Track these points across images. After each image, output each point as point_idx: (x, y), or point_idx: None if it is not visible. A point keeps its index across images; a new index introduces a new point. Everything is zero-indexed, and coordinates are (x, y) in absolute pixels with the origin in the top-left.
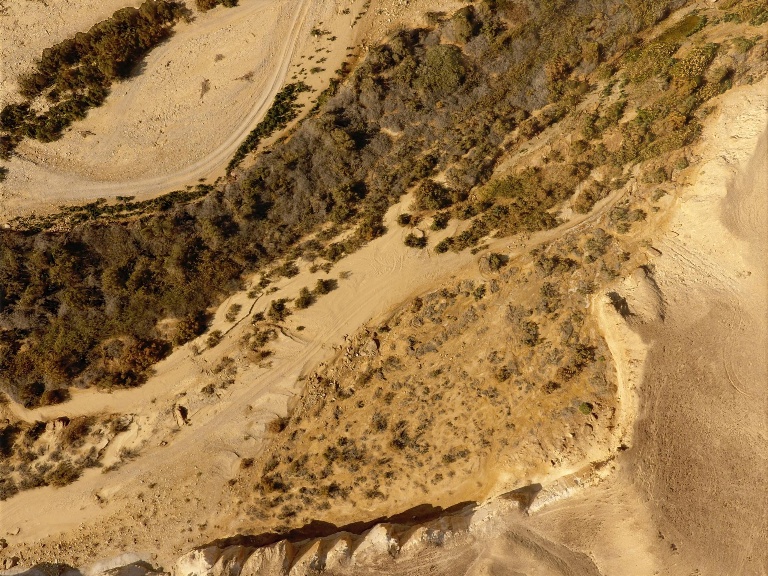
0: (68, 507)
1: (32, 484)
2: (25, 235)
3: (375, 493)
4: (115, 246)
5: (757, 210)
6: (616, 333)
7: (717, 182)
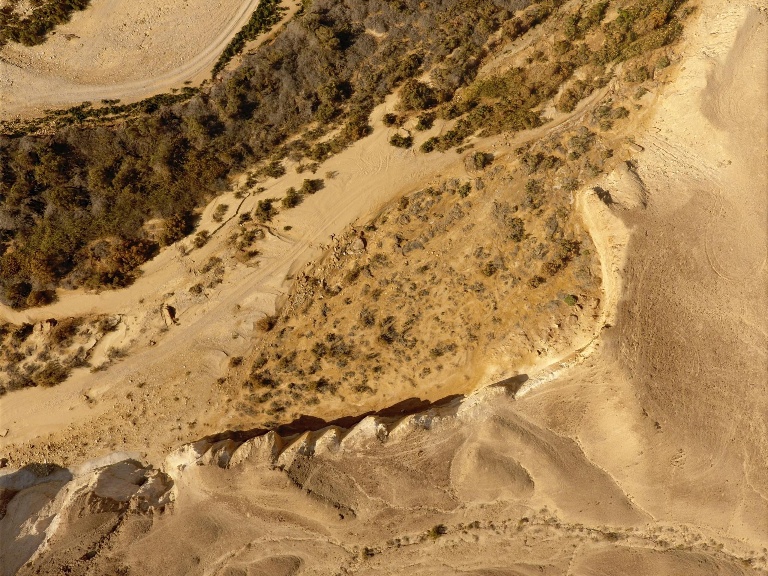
0: (57, 408)
1: (20, 384)
2: (10, 137)
3: (363, 387)
4: (101, 147)
5: (737, 101)
6: (599, 221)
7: (697, 75)
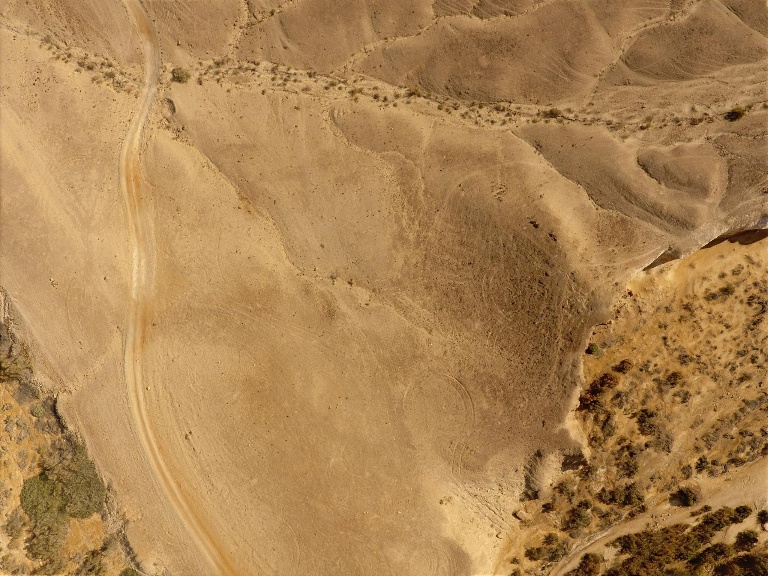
0: None
1: None
2: None
3: None
4: None
5: (430, 572)
6: None
7: None
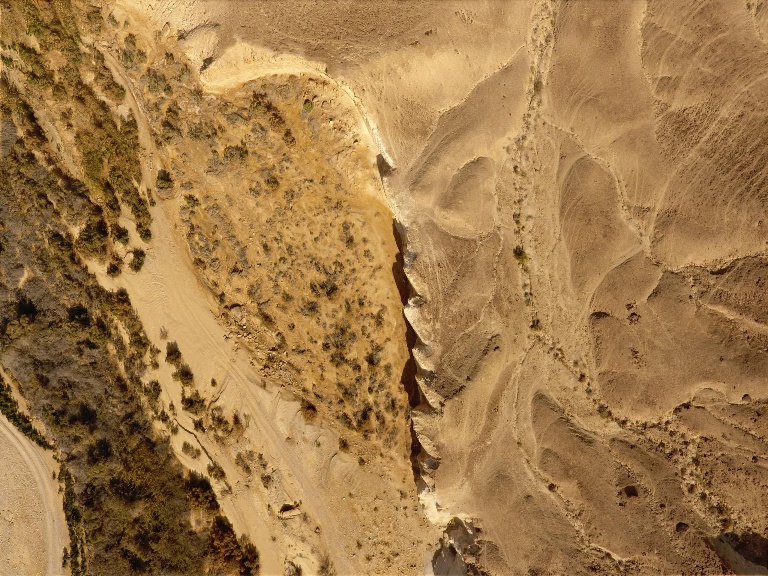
0: None
1: None
2: None
3: (377, 318)
4: (109, 571)
5: None
6: (228, 71)
7: None
